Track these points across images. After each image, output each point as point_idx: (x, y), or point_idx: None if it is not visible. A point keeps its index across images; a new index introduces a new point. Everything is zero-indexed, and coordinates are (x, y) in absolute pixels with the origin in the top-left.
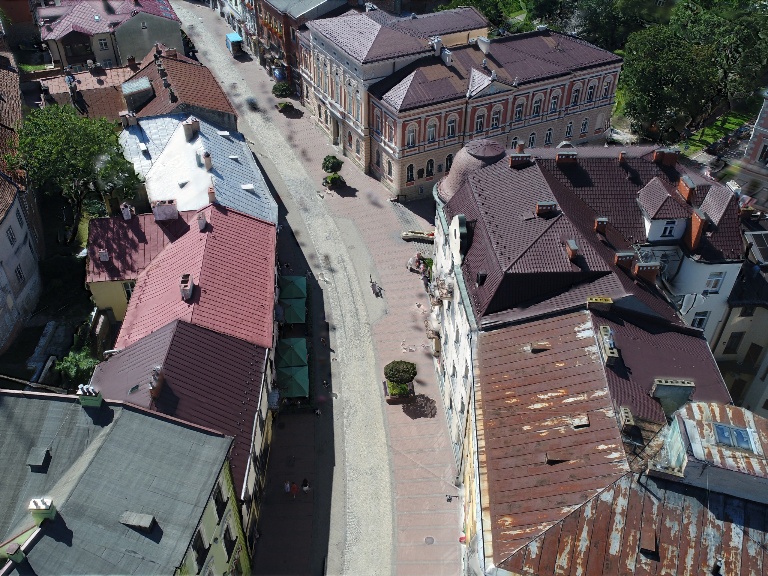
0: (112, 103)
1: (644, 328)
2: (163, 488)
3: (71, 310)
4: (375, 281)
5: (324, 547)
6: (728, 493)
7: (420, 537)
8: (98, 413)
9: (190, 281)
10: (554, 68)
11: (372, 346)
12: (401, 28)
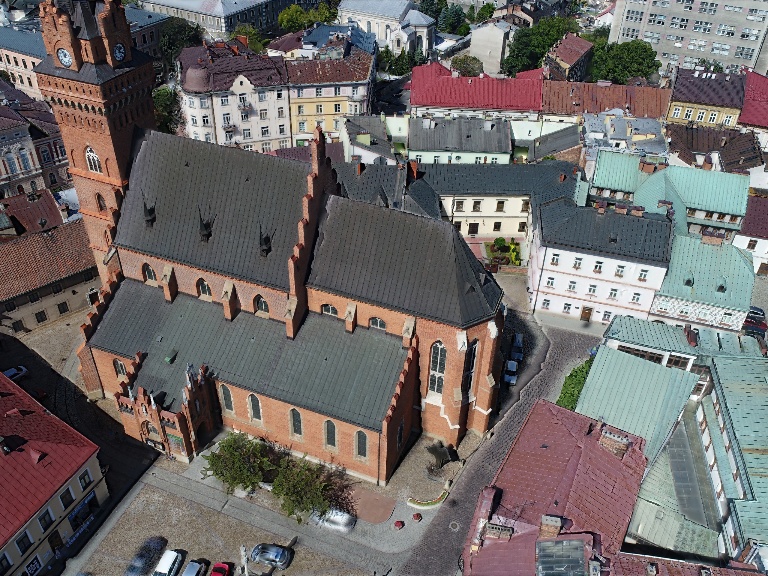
0: (7, 240)
1: None
2: None
3: None
4: None
5: None
6: None
7: None
8: (348, 121)
9: None
10: (17, 91)
11: None
12: None
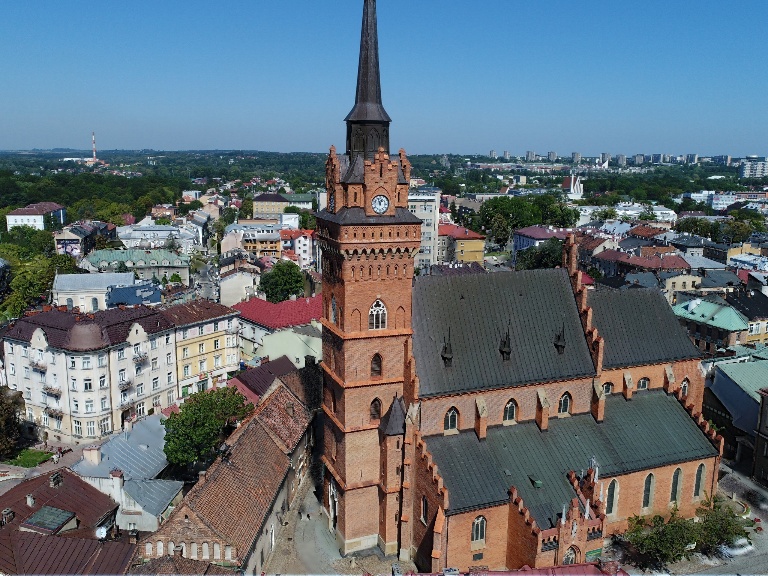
0: None
1: None
2: None
3: None
4: None
5: None
6: None
7: None
8: None
9: (221, 380)
10: None
11: None
12: None
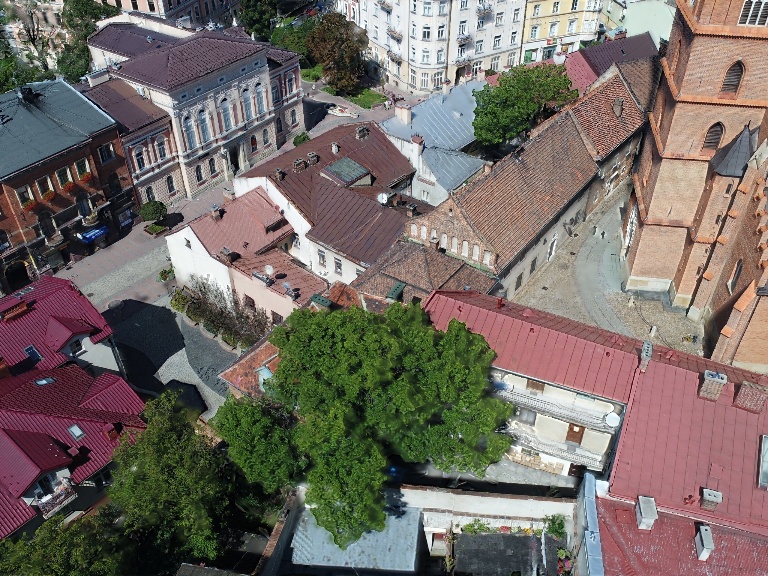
0: (372, 192)
1: None
2: None
3: None
4: None
5: None
6: None
7: None
8: None
9: None
10: None
11: None
12: (182, 41)
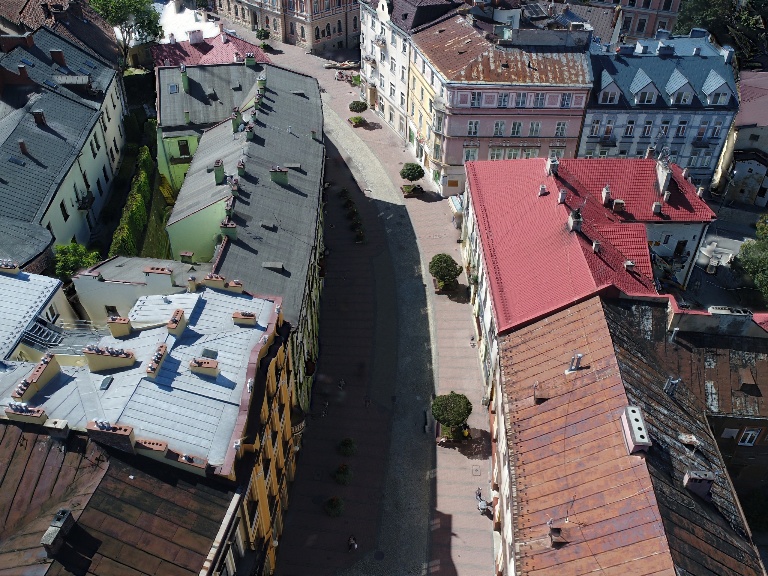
0: None
1: (484, 21)
2: (300, 87)
3: (150, 102)
4: (320, 85)
5: (350, 173)
6: (529, 44)
7: (396, 163)
8: (255, 67)
9: None
10: None
11: (333, 110)
12: None
